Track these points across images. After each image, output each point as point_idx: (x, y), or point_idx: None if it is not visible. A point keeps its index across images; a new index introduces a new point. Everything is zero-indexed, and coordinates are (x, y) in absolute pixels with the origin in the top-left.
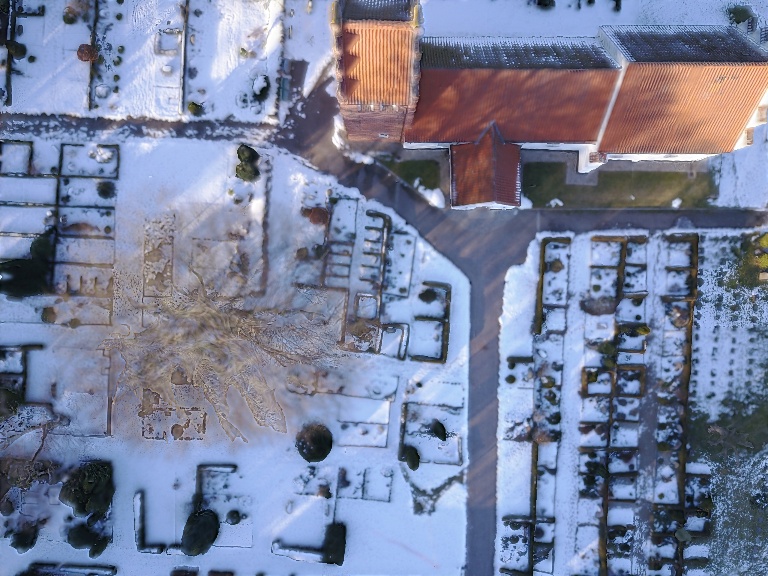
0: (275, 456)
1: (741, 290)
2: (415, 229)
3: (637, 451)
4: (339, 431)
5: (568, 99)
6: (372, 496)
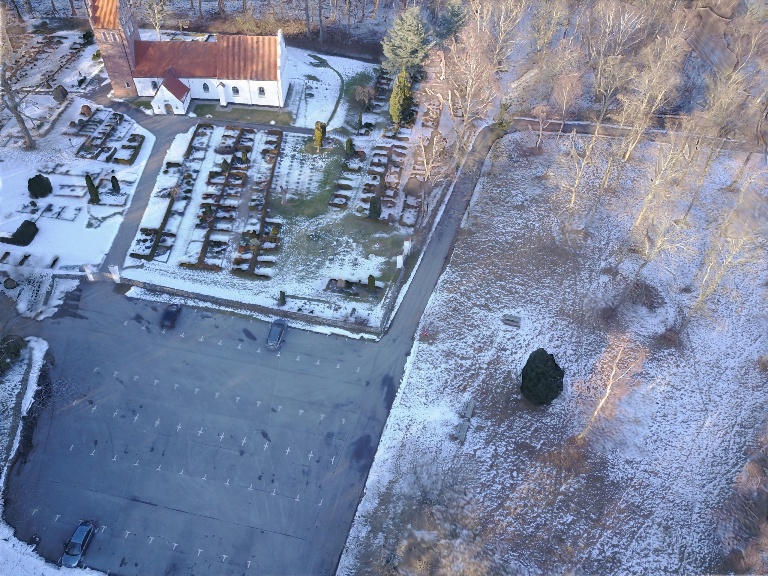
0: (14, 196)
1: (307, 155)
2: (135, 121)
3: (236, 210)
4: (58, 190)
5: (199, 55)
6: (63, 218)
